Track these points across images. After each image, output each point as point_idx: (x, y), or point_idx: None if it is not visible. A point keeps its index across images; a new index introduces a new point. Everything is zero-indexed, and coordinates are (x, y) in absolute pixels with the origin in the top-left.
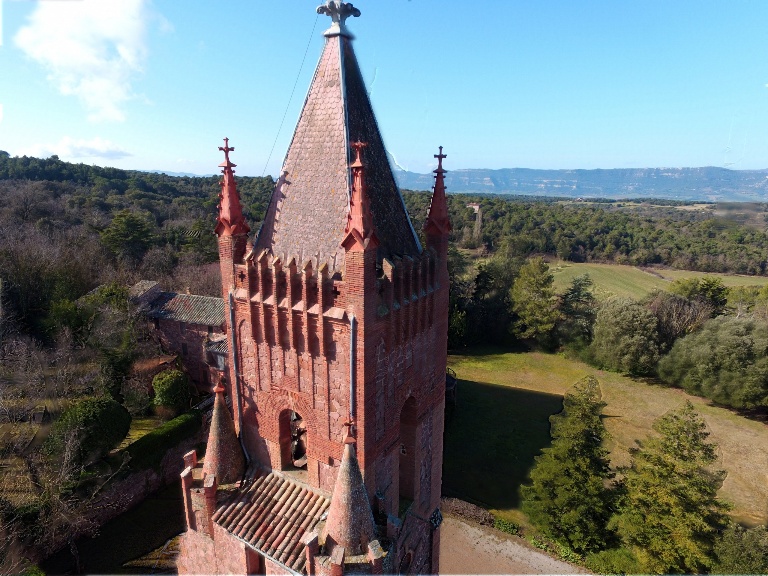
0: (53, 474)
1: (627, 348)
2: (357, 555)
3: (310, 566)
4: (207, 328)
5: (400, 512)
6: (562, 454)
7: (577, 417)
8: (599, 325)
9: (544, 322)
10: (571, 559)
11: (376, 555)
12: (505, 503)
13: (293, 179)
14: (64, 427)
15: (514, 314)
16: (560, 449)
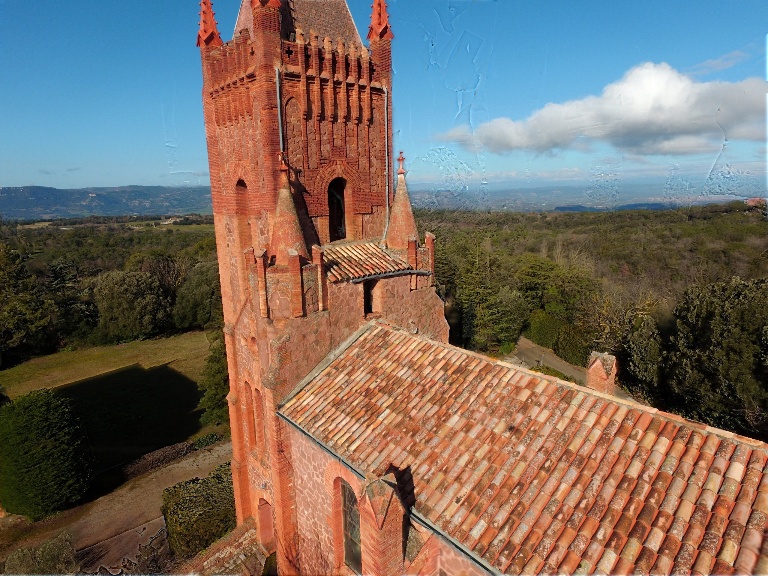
0: None
1: (144, 309)
2: None
3: None
4: None
5: None
6: None
7: None
8: (103, 301)
9: (36, 318)
10: None
11: None
12: (179, 438)
13: None
14: None
15: None
16: None
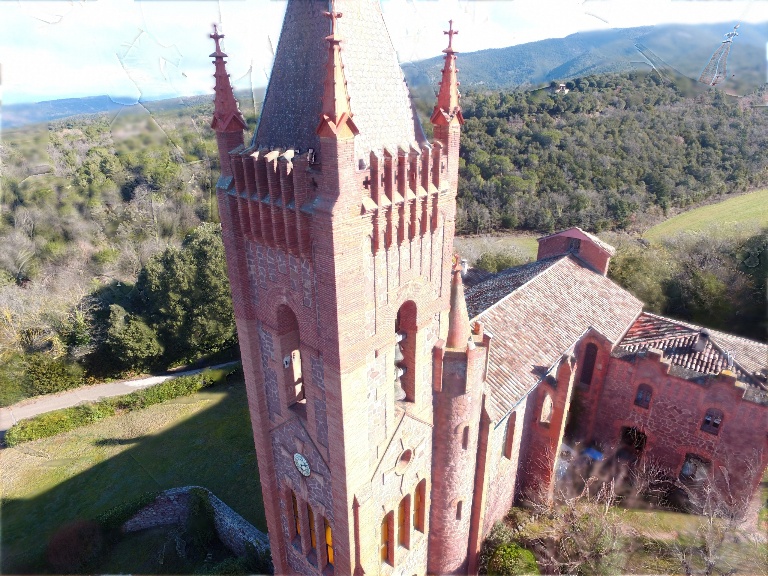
0: None
1: None
2: None
3: None
4: None
5: None
6: None
7: None
8: None
9: None
10: None
11: None
12: None
13: None
14: None
15: None
16: None
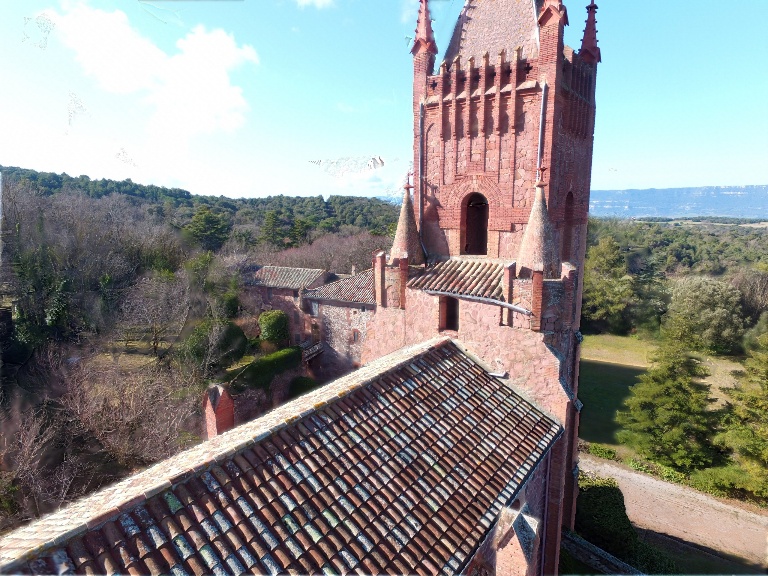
0: (197, 363)
1: (708, 322)
2: (549, 279)
3: (509, 289)
4: (293, 293)
5: None
6: (661, 375)
7: (676, 337)
8: (675, 302)
9: (615, 302)
10: (674, 479)
11: (571, 268)
12: (597, 438)
13: (478, 3)
14: (208, 322)
15: (583, 295)
16: (658, 371)
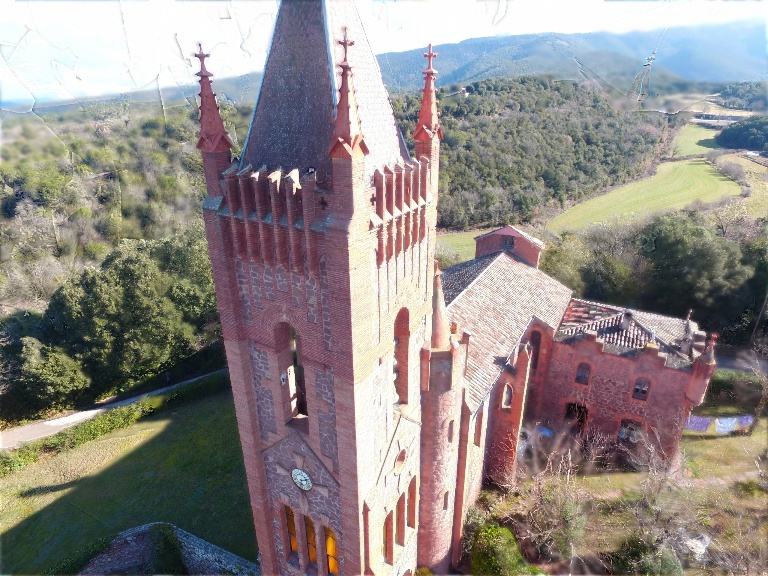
0: None
1: None
2: None
3: None
4: None
5: (295, 370)
6: None
7: None
8: None
9: None
10: None
11: None
12: None
13: None
14: None
15: None
16: None
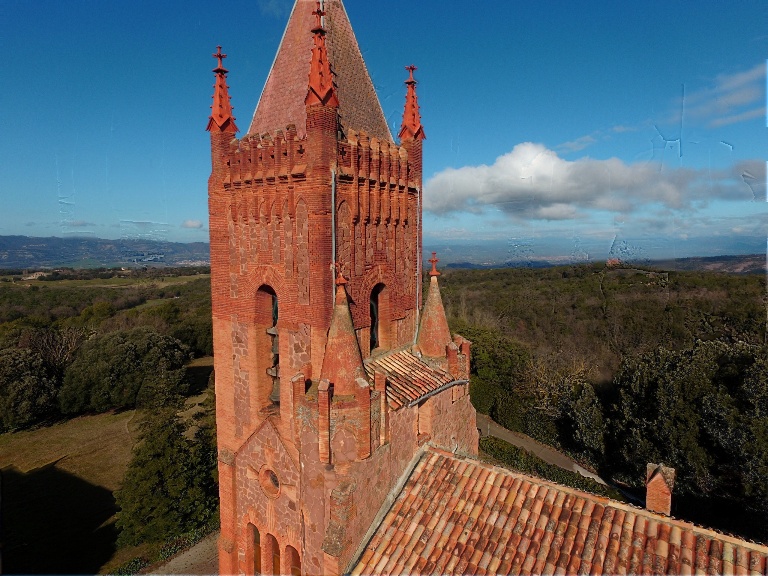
0: None
1: (21, 395)
2: None
3: None
4: None
5: None
6: (161, 447)
7: None
8: None
9: None
10: (198, 537)
11: None
12: (87, 570)
13: (338, 72)
14: None
15: None
16: (155, 445)
